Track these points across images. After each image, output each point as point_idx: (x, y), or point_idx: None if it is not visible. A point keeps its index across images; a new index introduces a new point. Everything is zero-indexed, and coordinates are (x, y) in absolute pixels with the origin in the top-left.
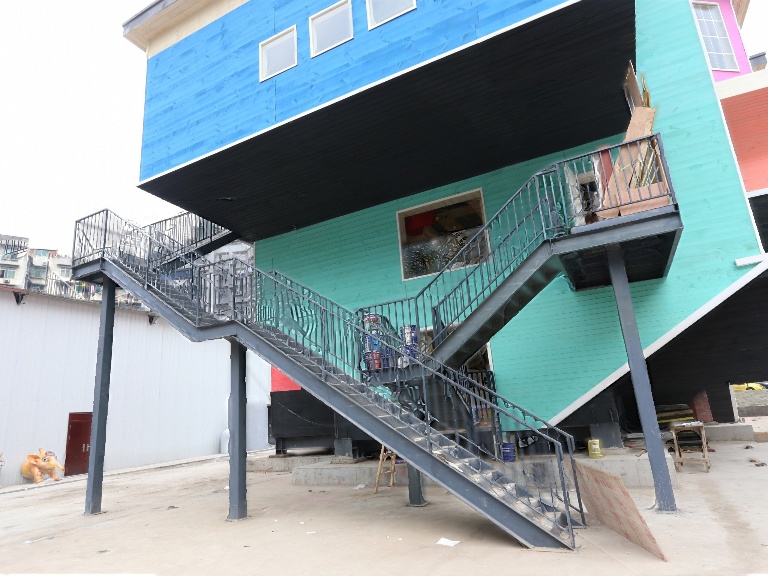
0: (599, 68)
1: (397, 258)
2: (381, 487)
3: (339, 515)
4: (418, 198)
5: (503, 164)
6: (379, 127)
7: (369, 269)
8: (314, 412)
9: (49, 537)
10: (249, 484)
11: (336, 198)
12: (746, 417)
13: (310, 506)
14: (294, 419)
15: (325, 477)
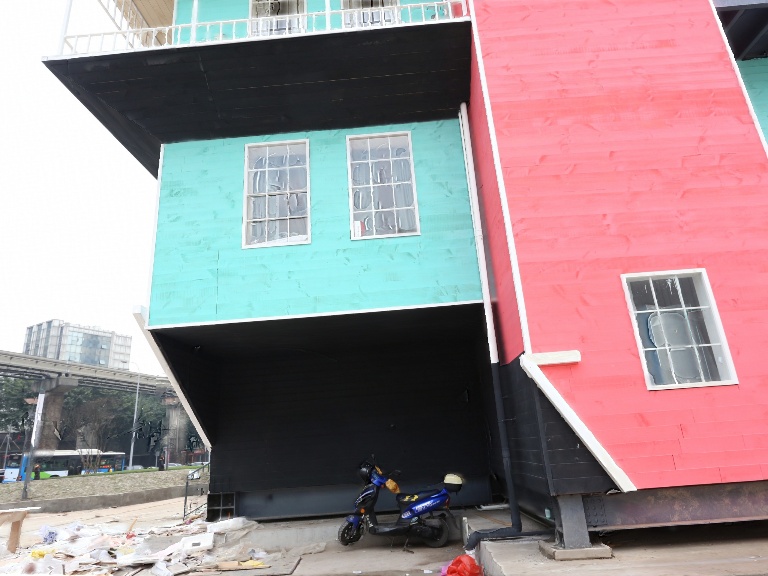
0: None
1: None
2: None
3: None
4: None
5: None
6: None
7: None
8: None
9: None
10: None
11: None
12: (156, 502)
13: None
14: None
15: None
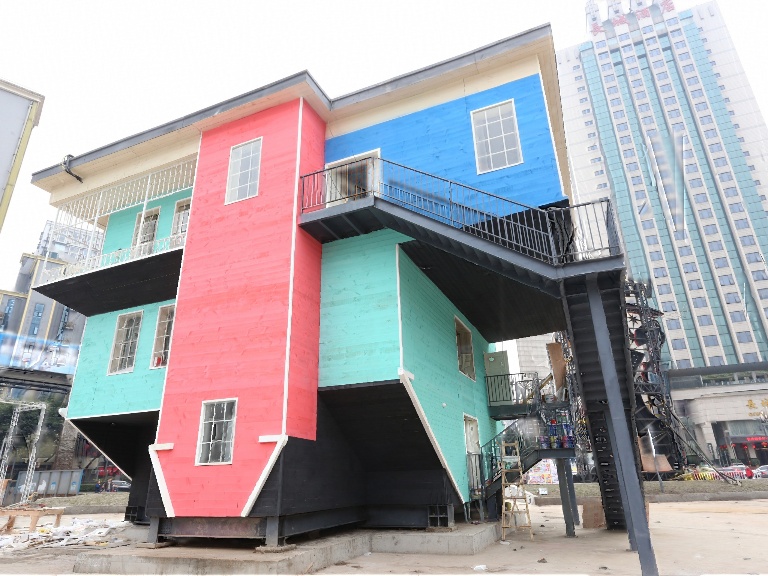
0: (543, 330)
1: (456, 351)
2: (506, 541)
3: (610, 541)
4: (459, 314)
5: (478, 326)
6: (547, 296)
7: (449, 349)
8: (327, 476)
9: (754, 573)
10: (446, 567)
11: (471, 285)
12: None
13: (586, 545)
14: (308, 484)
15: (483, 541)
